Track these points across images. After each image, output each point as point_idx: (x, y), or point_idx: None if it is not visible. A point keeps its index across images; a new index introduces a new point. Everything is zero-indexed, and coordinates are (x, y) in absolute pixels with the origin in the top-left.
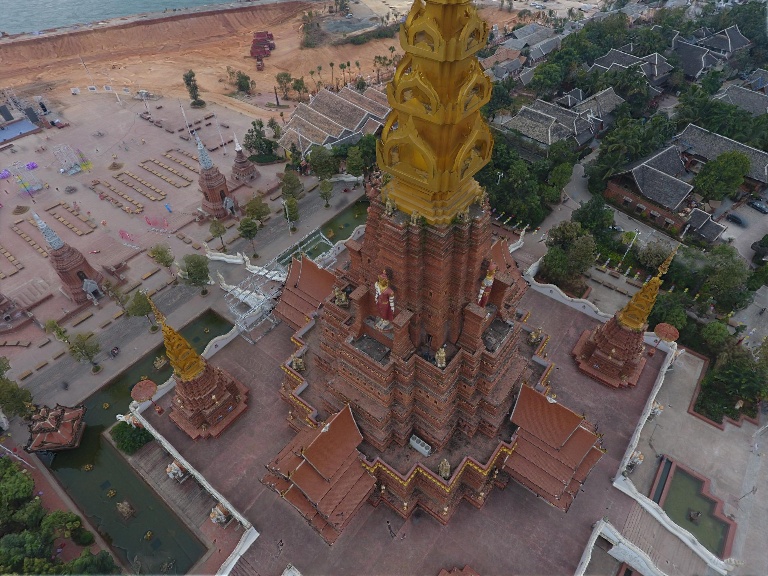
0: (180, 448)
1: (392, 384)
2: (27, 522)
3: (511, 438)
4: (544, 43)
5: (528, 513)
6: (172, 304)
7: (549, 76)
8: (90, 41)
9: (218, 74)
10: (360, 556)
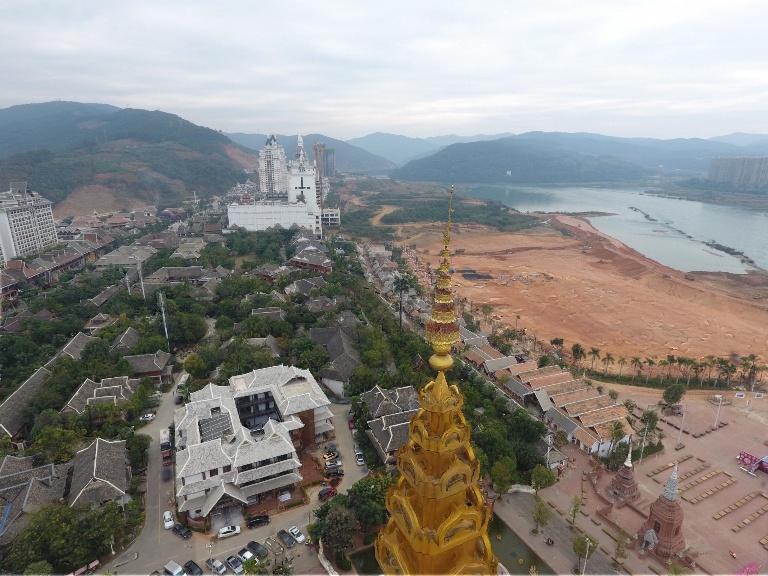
0: None
1: None
2: None
3: None
4: None
5: None
6: None
7: None
8: None
9: None
10: None
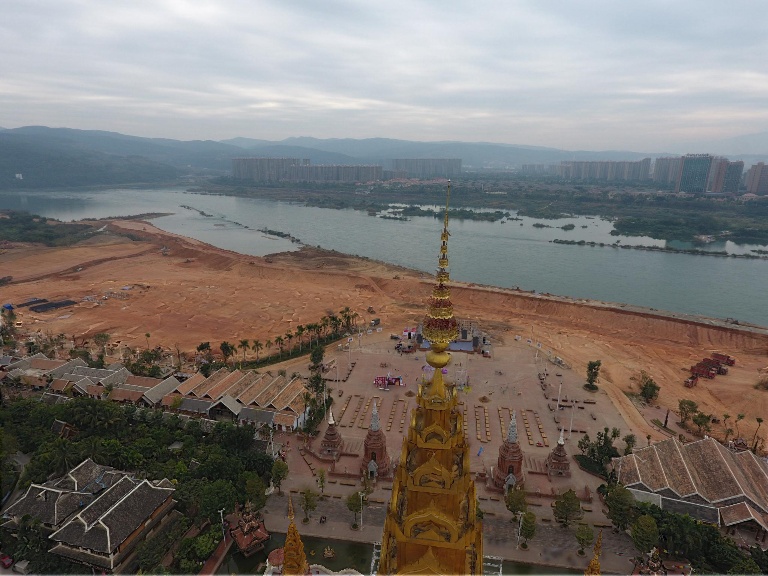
0: None
1: None
2: (182, 570)
3: None
4: None
5: None
6: None
7: None
8: (565, 310)
9: (638, 372)
10: None
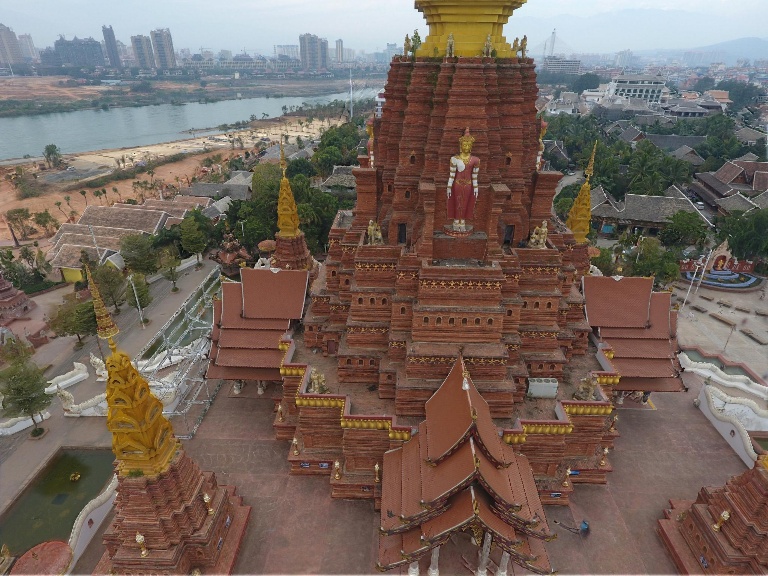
0: None
1: (499, 302)
2: None
3: (599, 345)
4: (297, 153)
5: (648, 426)
6: None
7: (333, 154)
8: None
9: None
10: None
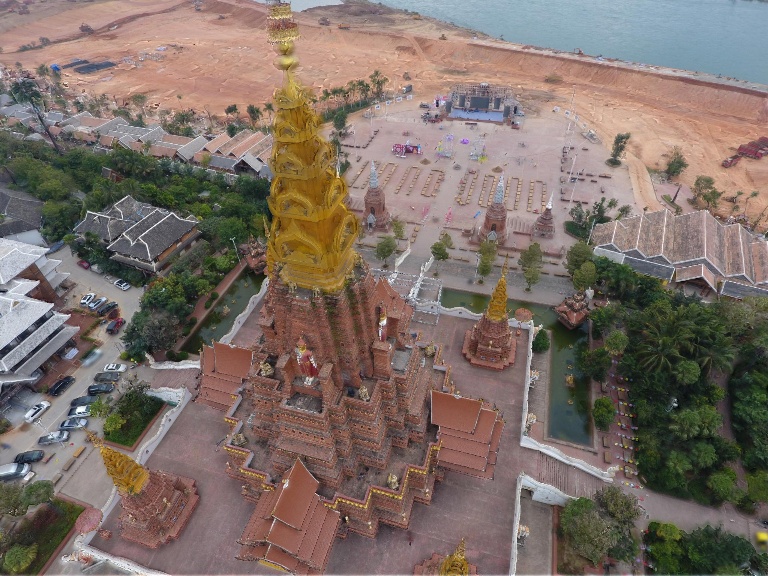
0: (255, 310)
1: None
2: None
3: (276, 483)
4: None
5: None
6: (373, 258)
7: None
8: (625, 78)
9: None
10: (202, 429)
